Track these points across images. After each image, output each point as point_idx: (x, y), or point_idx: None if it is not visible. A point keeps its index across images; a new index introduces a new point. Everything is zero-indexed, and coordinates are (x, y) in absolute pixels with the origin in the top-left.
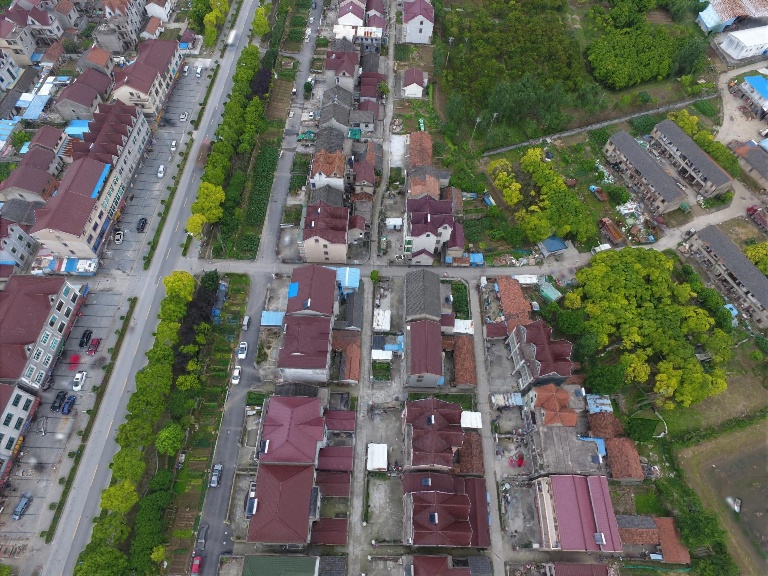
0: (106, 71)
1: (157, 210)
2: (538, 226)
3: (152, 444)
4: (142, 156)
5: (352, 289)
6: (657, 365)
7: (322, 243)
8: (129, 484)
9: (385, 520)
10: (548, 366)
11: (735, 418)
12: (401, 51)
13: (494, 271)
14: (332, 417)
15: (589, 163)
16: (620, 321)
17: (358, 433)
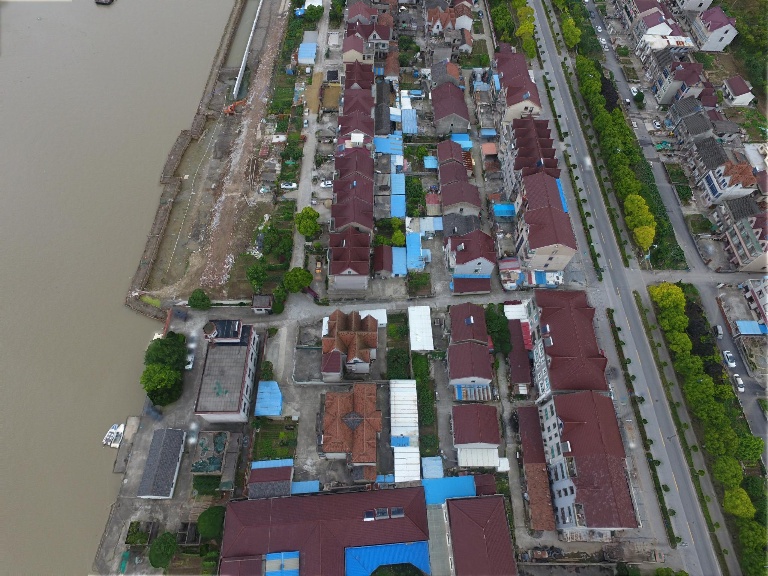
0: (458, 84)
1: (574, 222)
2: None
3: None
4: None
5: None
6: None
7: None
8: None
9: None
10: None
11: None
12: (702, 59)
13: None
14: None
15: None
16: None
17: None
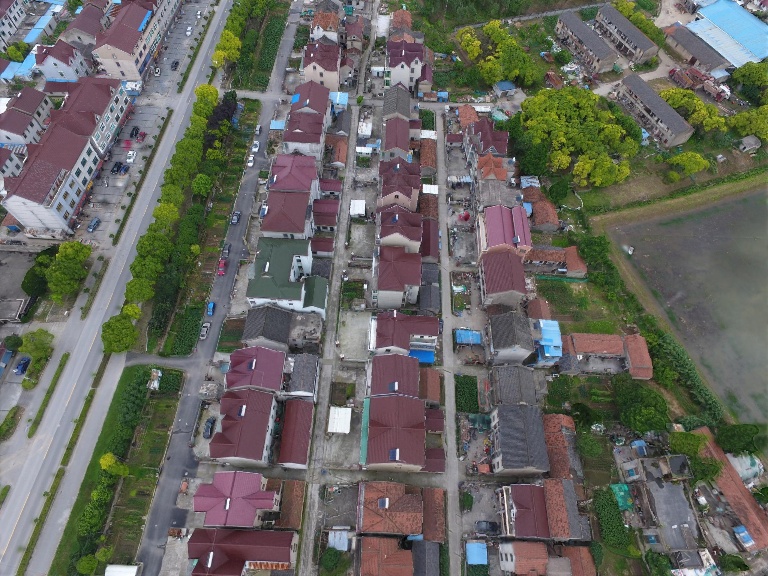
0: None
1: (187, 57)
2: (492, 69)
3: (189, 186)
4: (174, 18)
5: (342, 109)
6: (577, 158)
7: (319, 71)
8: (173, 206)
9: (362, 247)
10: (489, 144)
11: (638, 201)
12: None
13: (457, 105)
14: (324, 181)
15: (541, 35)
16: (551, 129)
17: (344, 198)
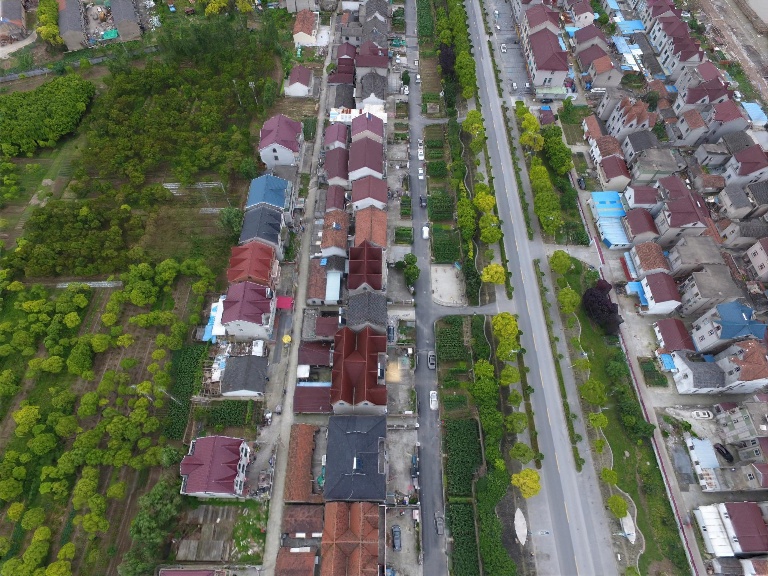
0: None
1: None
2: None
3: None
4: None
5: None
6: None
7: None
8: None
9: None
10: None
11: None
12: (308, 129)
13: None
14: None
15: None
16: None
17: None
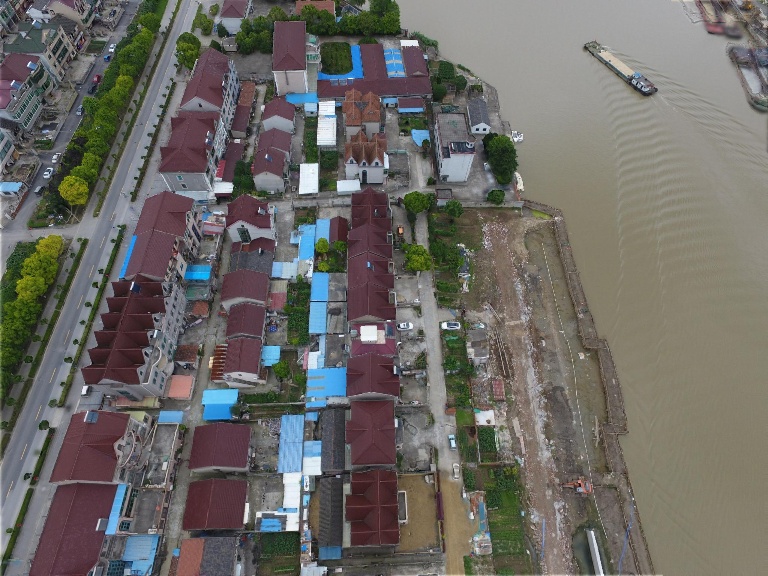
0: None
1: None
2: None
3: None
4: None
5: None
6: None
7: None
8: None
9: None
10: None
11: None
12: None
13: None
14: None
15: None
16: None
17: None
